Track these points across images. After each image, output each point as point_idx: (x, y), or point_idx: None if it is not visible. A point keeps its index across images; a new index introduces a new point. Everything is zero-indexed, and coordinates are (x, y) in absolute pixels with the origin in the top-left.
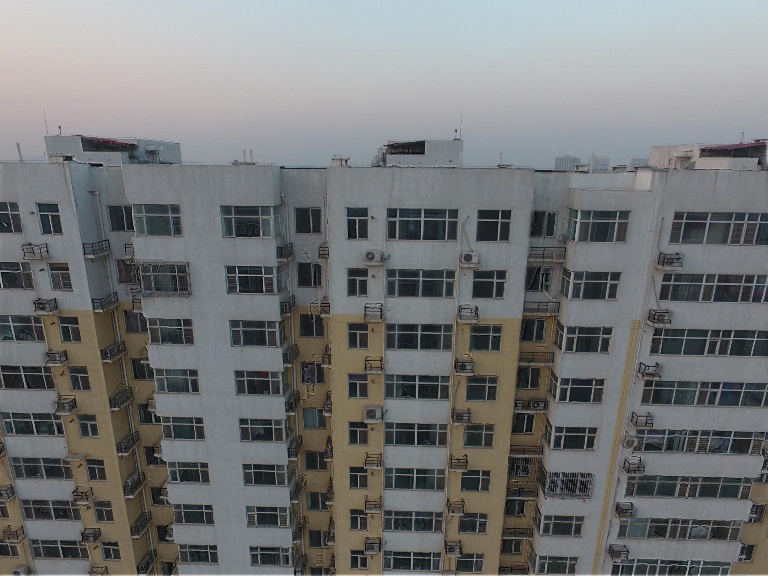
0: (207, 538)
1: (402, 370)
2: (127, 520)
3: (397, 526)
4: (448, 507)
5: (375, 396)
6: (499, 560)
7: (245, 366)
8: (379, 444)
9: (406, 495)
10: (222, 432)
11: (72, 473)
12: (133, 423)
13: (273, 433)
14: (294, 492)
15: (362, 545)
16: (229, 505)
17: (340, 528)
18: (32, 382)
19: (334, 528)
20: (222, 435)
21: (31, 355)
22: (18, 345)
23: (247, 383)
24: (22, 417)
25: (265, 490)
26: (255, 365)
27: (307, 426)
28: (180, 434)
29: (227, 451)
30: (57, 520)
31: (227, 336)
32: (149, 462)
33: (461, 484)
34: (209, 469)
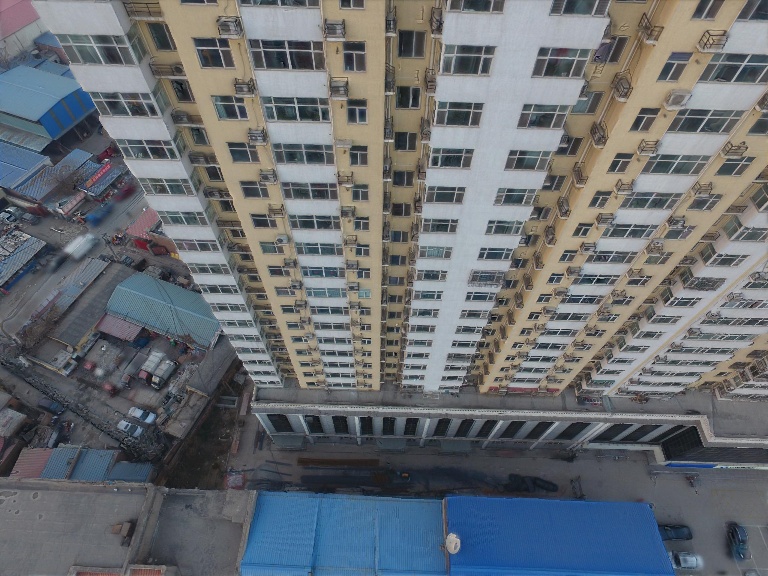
0: (453, 214)
1: (739, 48)
2: (382, 200)
3: (631, 204)
4: (698, 189)
5: (689, 79)
6: (707, 230)
7: (555, 42)
8: (662, 131)
9: (659, 179)
10: (500, 118)
11: (335, 159)
12: (390, 108)
13: (553, 120)
14: (546, 176)
15: (592, 219)
16: (483, 187)
17: (580, 206)
18: (298, 61)
19: (567, 206)
20: (500, 122)
21: (300, 26)
22: (285, 12)
23: (547, 63)
24: (284, 102)
25: (523, 174)
26: (568, 40)
27: (574, 111)
28: (452, 120)
29: (499, 138)
30: (315, 199)
31: (550, 1)
32: (396, 147)
33: (719, 169)
34: (474, 155)
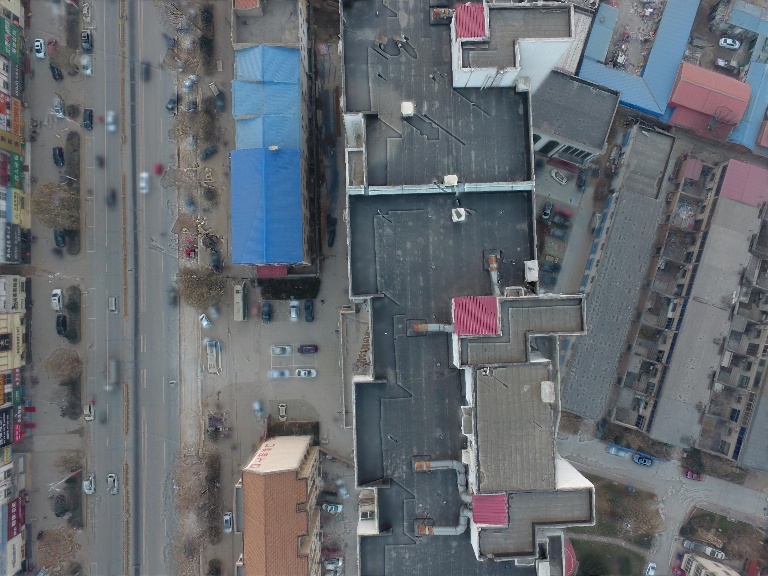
0: None
1: None
2: None
3: None
4: None
5: None
6: None
7: None
8: None
9: None
10: None
11: None
12: None
13: None
14: None
15: None
16: None
17: None
18: None
19: None
20: None
21: None
22: None
23: None
24: None
25: None
26: None
27: None
28: None
29: None
30: None
31: None
32: None
33: None
34: None
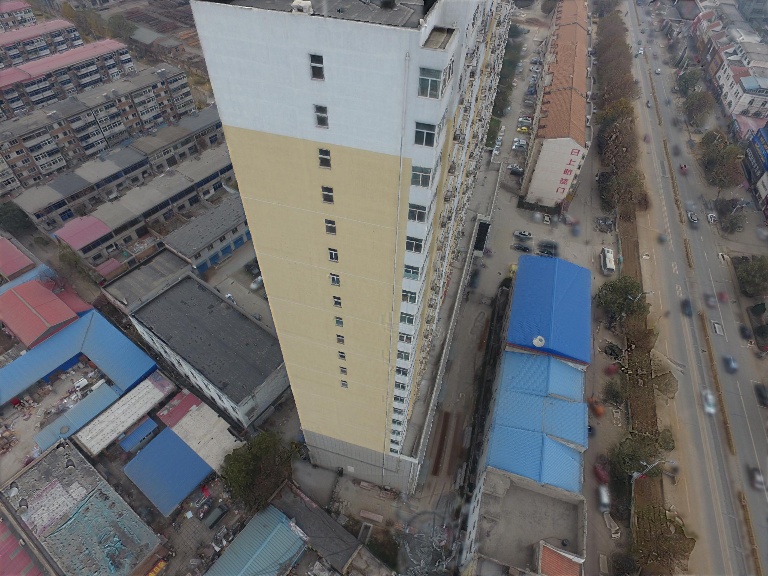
0: None
1: None
2: None
3: None
4: None
5: None
6: None
7: None
8: None
9: None
10: None
11: None
12: None
13: None
14: None
15: None
16: None
17: None
18: None
19: None
20: None
21: None
22: None
23: None
24: None
25: None
26: None
27: None
28: None
29: None
30: None
31: None
32: None
33: (484, 87)
34: (466, 138)
